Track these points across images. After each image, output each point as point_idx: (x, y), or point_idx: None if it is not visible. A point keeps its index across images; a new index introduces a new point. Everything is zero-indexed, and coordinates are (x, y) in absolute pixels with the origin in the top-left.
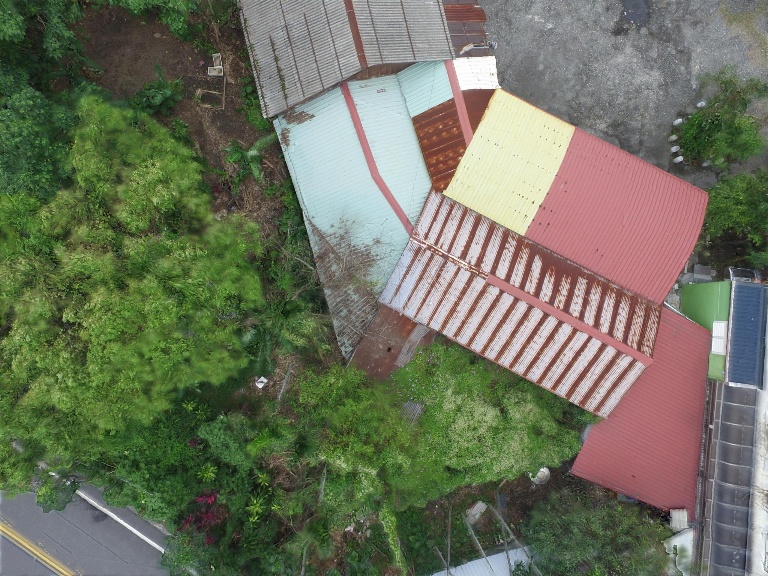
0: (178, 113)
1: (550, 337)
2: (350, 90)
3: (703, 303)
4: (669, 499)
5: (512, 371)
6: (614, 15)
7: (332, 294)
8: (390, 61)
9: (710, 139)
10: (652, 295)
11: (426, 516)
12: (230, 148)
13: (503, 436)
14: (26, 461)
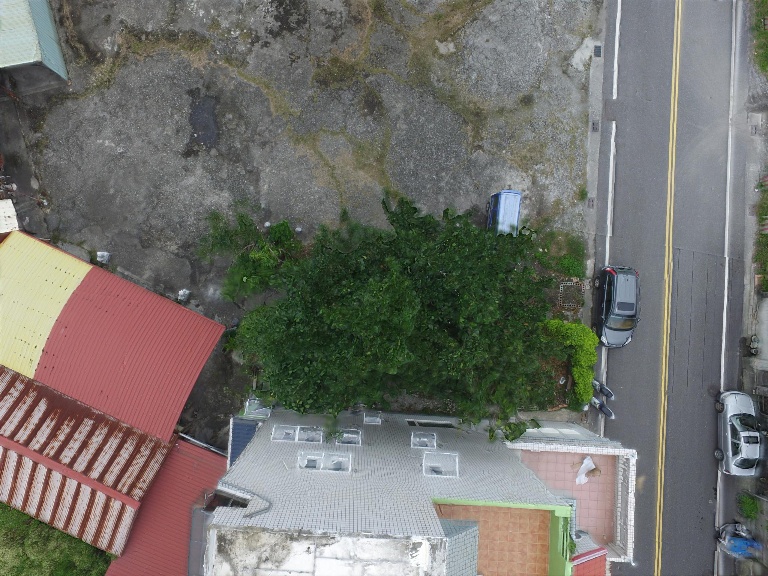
0: None
1: (45, 483)
2: None
3: None
4: None
5: (25, 513)
6: (184, 137)
7: None
8: None
9: None
10: (160, 433)
11: None
12: None
13: (26, 575)
14: None
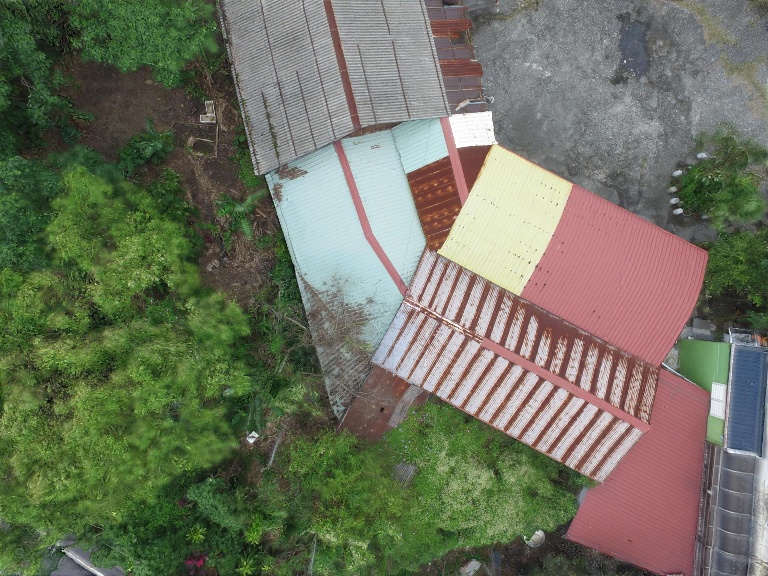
0: (170, 161)
1: (545, 401)
2: (343, 147)
3: (702, 362)
4: (666, 563)
5: (507, 434)
6: (614, 63)
7: (324, 352)
8: (384, 121)
9: (710, 195)
10: (650, 357)
11: (419, 574)
12: None
13: (497, 499)
14: (7, 546)
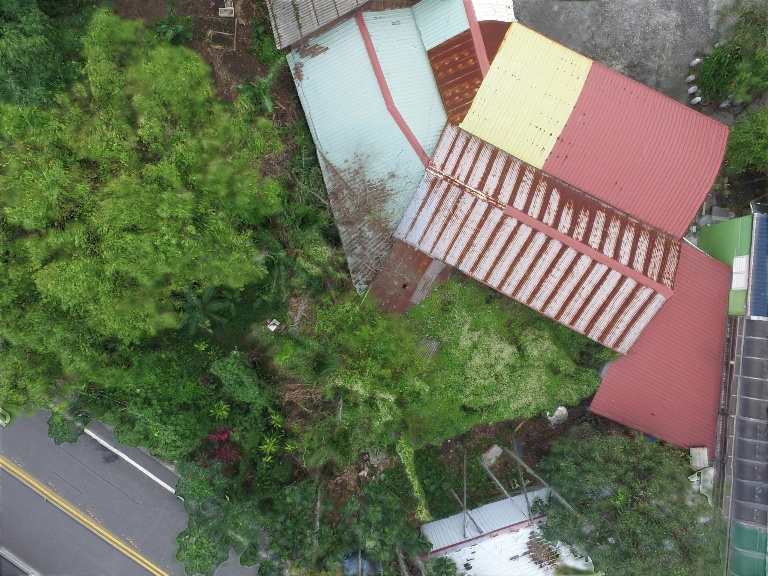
0: (189, 55)
1: (569, 270)
2: (365, 21)
3: (722, 241)
4: (689, 438)
5: None
6: None
7: (346, 231)
8: None
9: (729, 75)
10: (672, 229)
11: (441, 460)
12: (242, 87)
13: (520, 374)
14: (40, 375)
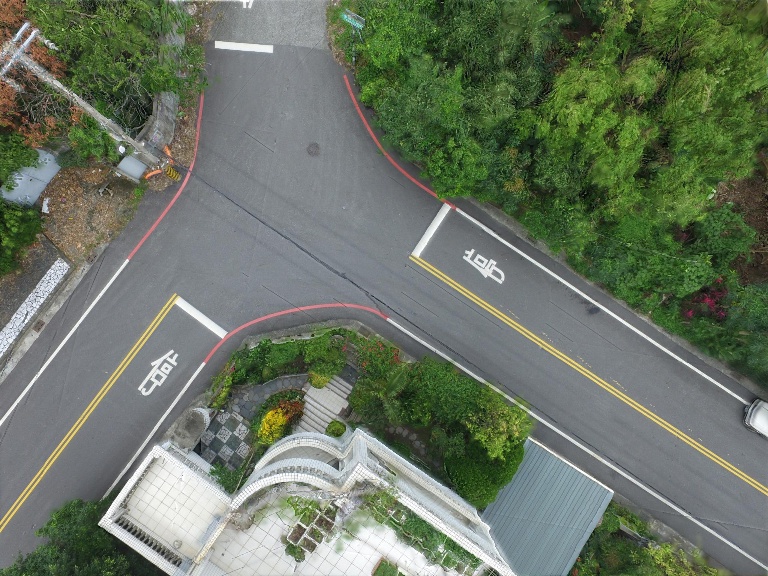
0: None
1: None
2: None
3: None
4: None
5: None
6: None
7: None
8: None
9: None
10: None
11: None
12: None
13: None
14: None
